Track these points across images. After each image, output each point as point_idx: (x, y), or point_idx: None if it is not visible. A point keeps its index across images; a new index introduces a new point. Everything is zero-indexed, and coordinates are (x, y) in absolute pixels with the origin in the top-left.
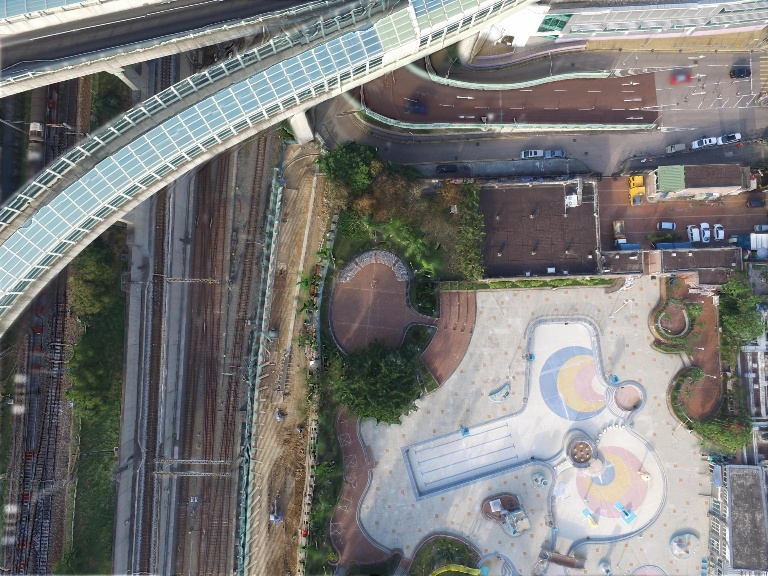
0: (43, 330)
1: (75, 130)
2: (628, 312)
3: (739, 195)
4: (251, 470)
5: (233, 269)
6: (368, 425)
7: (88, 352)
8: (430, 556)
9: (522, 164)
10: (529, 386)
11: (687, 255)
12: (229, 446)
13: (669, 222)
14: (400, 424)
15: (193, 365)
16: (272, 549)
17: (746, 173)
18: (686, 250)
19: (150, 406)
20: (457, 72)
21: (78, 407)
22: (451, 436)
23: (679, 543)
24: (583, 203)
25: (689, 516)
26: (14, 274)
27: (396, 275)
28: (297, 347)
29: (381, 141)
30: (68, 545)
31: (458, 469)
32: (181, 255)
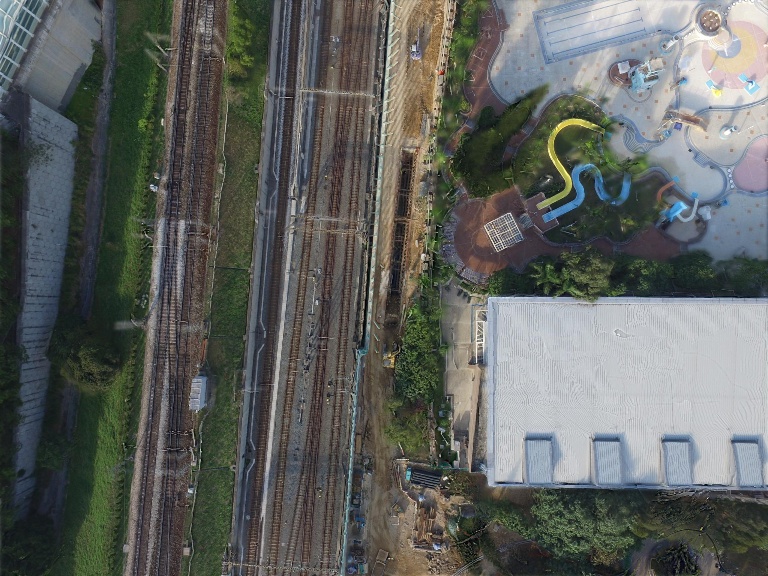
0: None
1: None
2: None
3: None
4: (392, 12)
5: None
6: None
7: None
8: (557, 114)
9: None
10: None
11: None
12: None
13: None
14: None
15: None
16: (410, 88)
17: None
18: None
19: None
20: None
21: None
22: (580, 9)
23: None
24: None
25: None
26: None
27: None
28: None
29: None
30: (230, 33)
31: (586, 40)
32: None
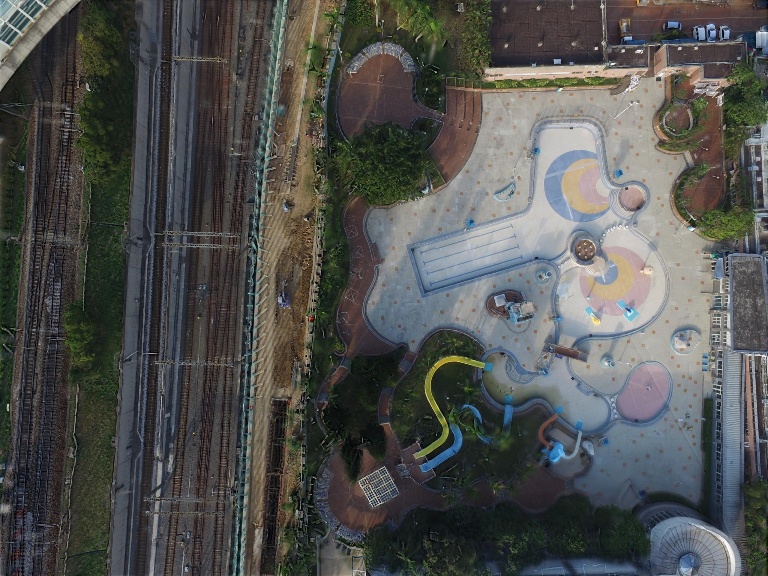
0: (53, 99)
1: None
2: (633, 114)
3: None
4: (259, 258)
5: (240, 66)
6: (374, 223)
7: (98, 103)
8: (435, 349)
9: None
10: (534, 187)
11: (692, 49)
12: (237, 237)
13: (675, 21)
14: (407, 200)
15: (201, 158)
16: (280, 335)
17: None
18: (692, 45)
19: (159, 191)
20: None
21: (88, 167)
22: (456, 237)
23: (680, 337)
24: None
25: (691, 313)
26: None
27: (403, 65)
28: (304, 138)
29: None
30: None
31: (463, 269)
32: (189, 47)
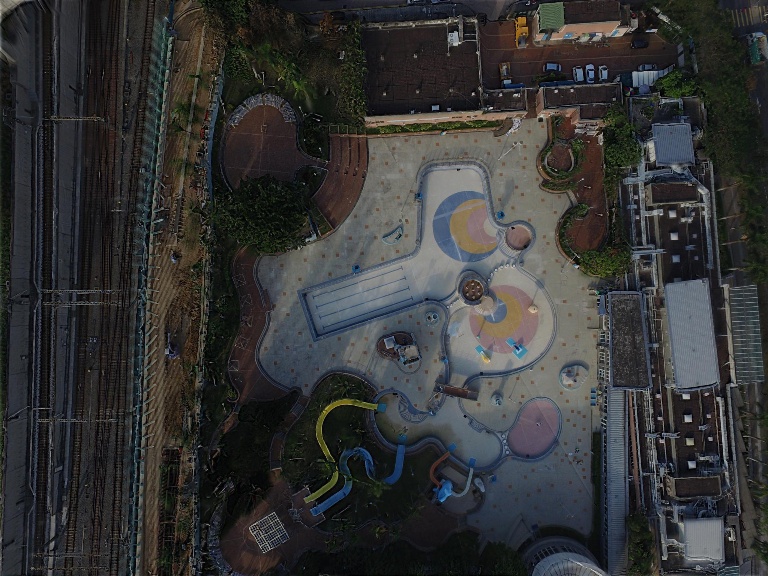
0: None
1: None
2: (517, 154)
3: (623, 37)
4: (147, 310)
5: (127, 119)
6: (265, 270)
7: None
8: (327, 393)
9: (409, 10)
10: (422, 229)
11: (569, 91)
12: (126, 289)
13: (554, 63)
14: (284, 251)
15: (89, 212)
16: (170, 385)
17: (626, 10)
18: (568, 87)
19: (44, 248)
20: None
21: None
22: (348, 281)
23: (568, 373)
24: (466, 42)
25: (578, 349)
26: None
27: (283, 116)
28: (189, 190)
29: None
30: None
31: (355, 312)
32: (72, 103)
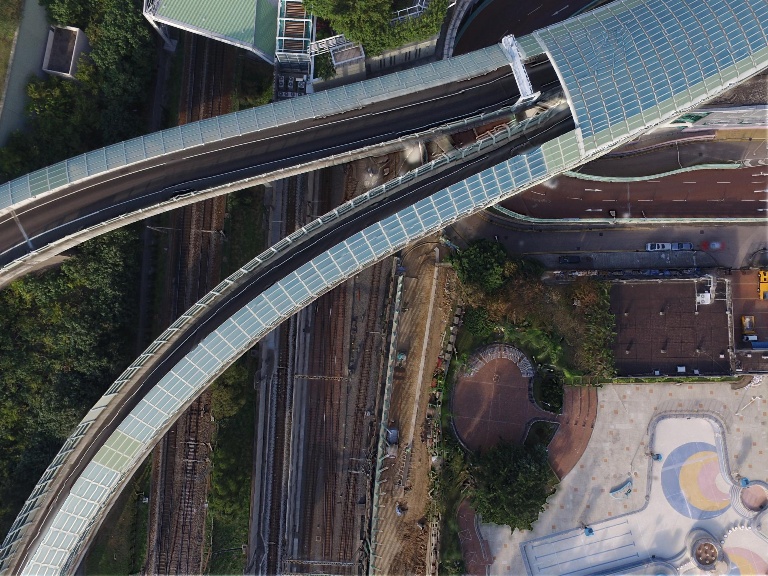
0: (177, 428)
1: (210, 227)
2: (755, 409)
3: None
4: (371, 565)
5: (352, 358)
6: None
7: (231, 460)
8: None
9: (647, 256)
10: (651, 483)
11: None
12: (348, 539)
13: None
14: None
15: (312, 456)
16: None
17: None
18: None
19: (273, 499)
20: (588, 167)
21: (215, 510)
22: None
23: None
24: (715, 300)
25: None
26: (179, 397)
27: (521, 371)
28: (419, 441)
29: (501, 229)
30: None
31: (576, 566)
32: (303, 345)
